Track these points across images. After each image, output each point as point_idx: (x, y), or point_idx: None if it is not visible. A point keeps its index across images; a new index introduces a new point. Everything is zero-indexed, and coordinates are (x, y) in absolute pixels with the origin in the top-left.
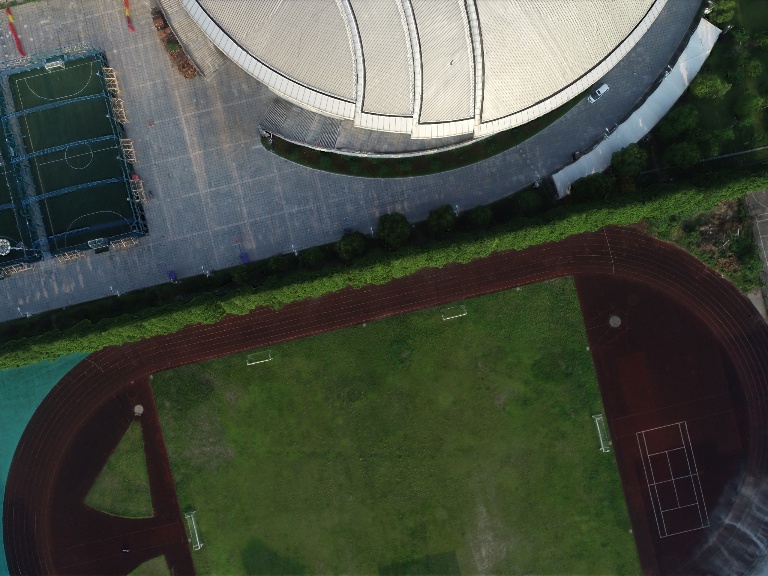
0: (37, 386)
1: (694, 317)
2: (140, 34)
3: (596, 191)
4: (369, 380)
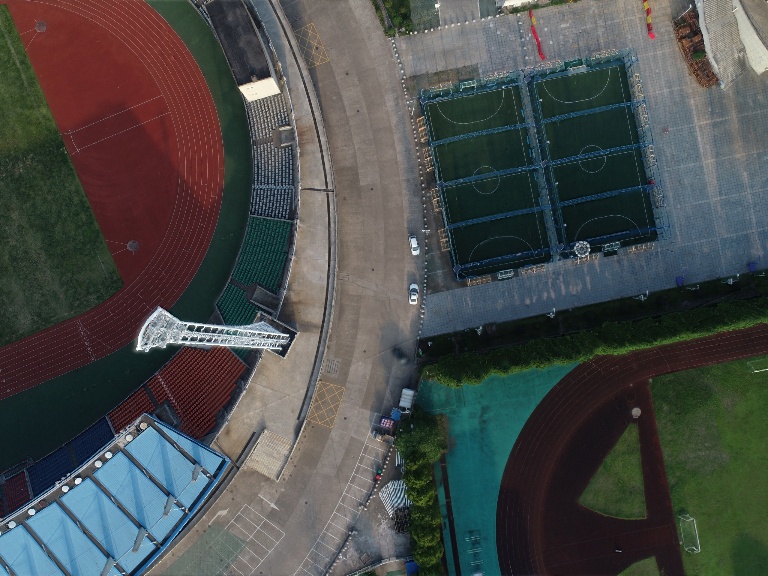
0: (537, 385)
1: None
2: (659, 41)
3: None
4: None
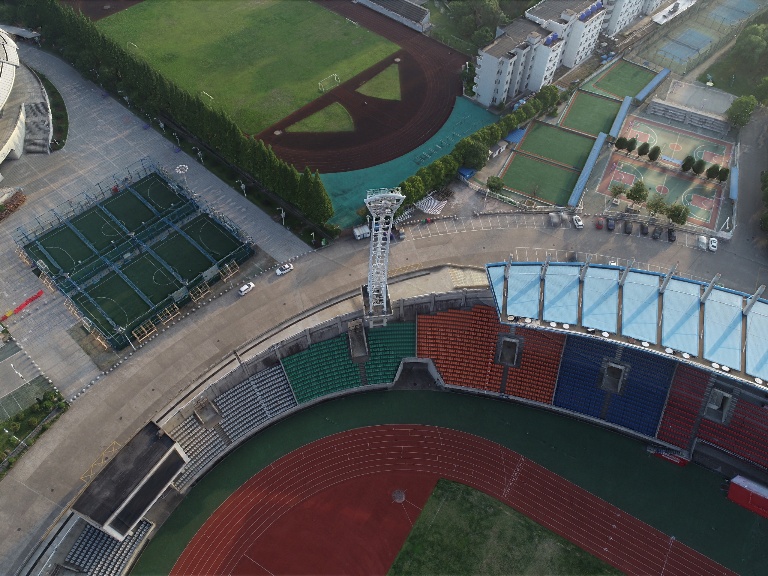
0: None
1: None
2: None
3: None
4: (193, 62)
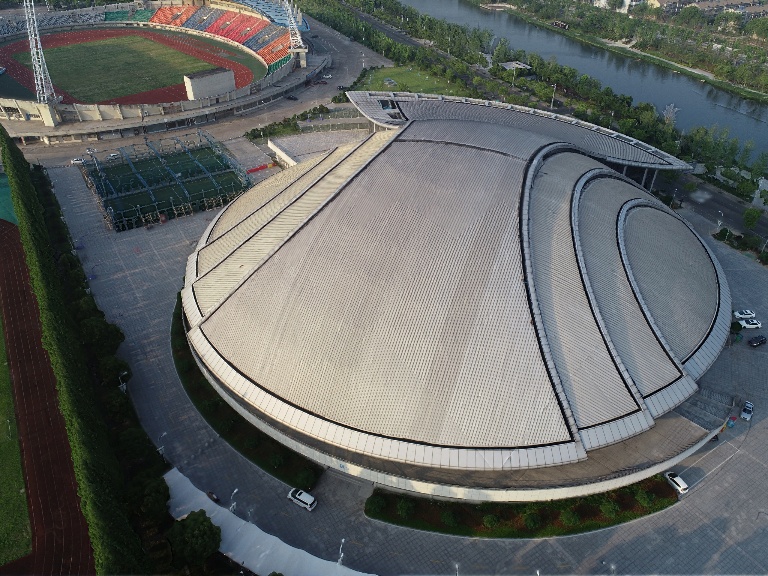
0: None
1: None
2: None
3: (136, 485)
4: None
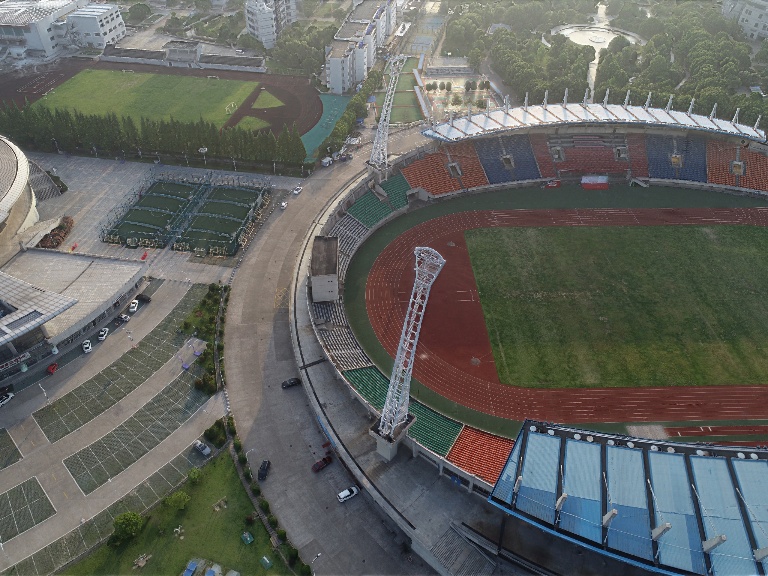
0: None
1: None
2: (74, 243)
3: None
4: None
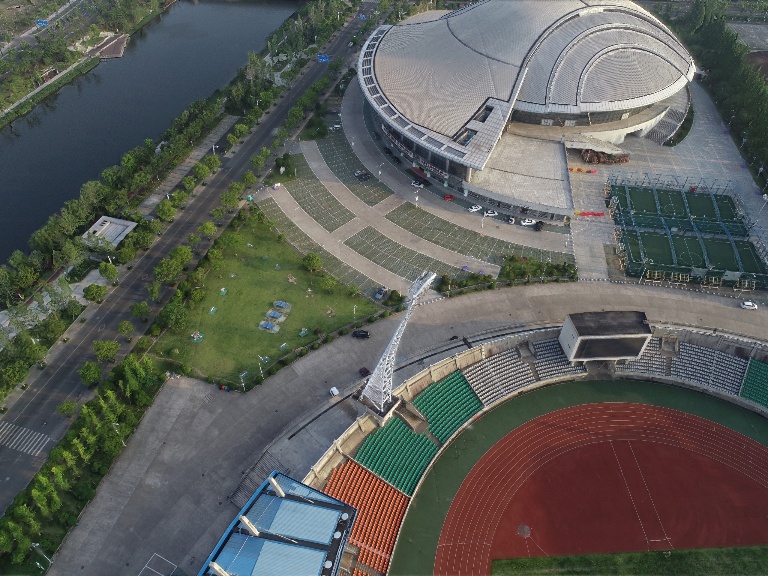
0: None
1: (764, 64)
2: None
3: None
4: None
